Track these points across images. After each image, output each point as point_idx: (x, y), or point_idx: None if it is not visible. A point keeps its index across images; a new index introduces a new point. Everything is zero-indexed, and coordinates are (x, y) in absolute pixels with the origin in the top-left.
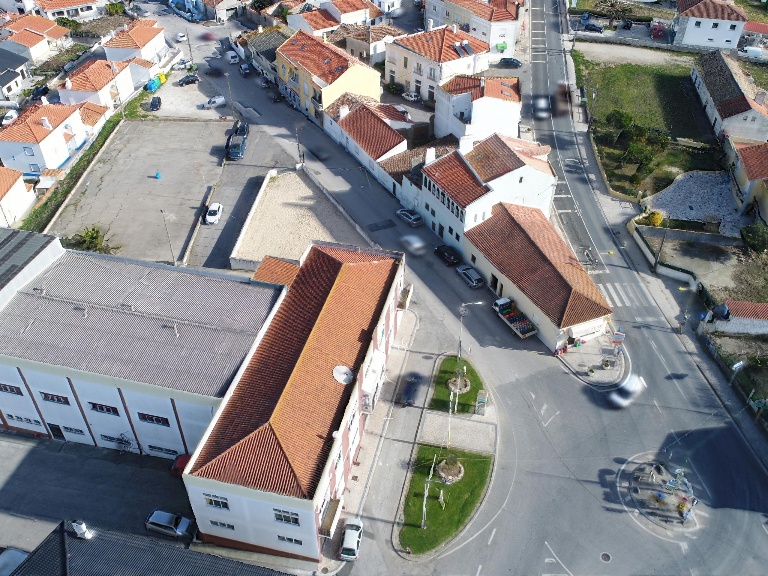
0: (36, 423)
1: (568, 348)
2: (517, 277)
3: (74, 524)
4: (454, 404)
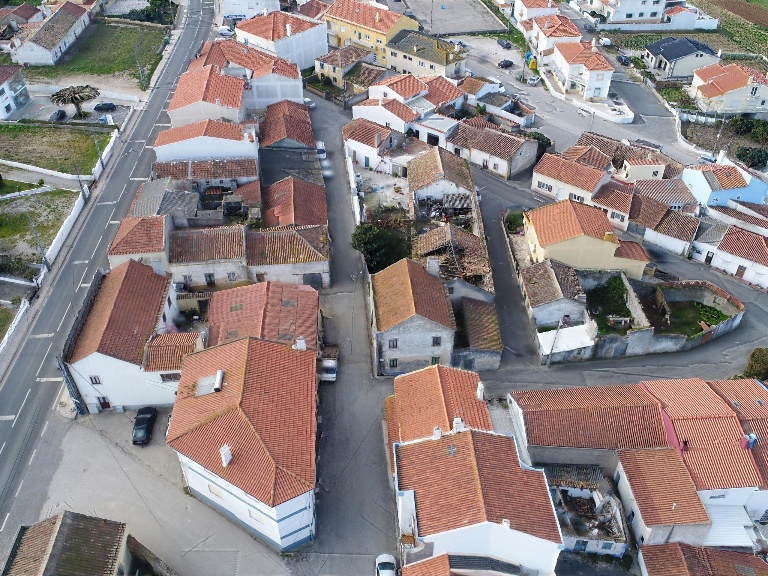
0: None
1: None
2: None
3: None
4: None
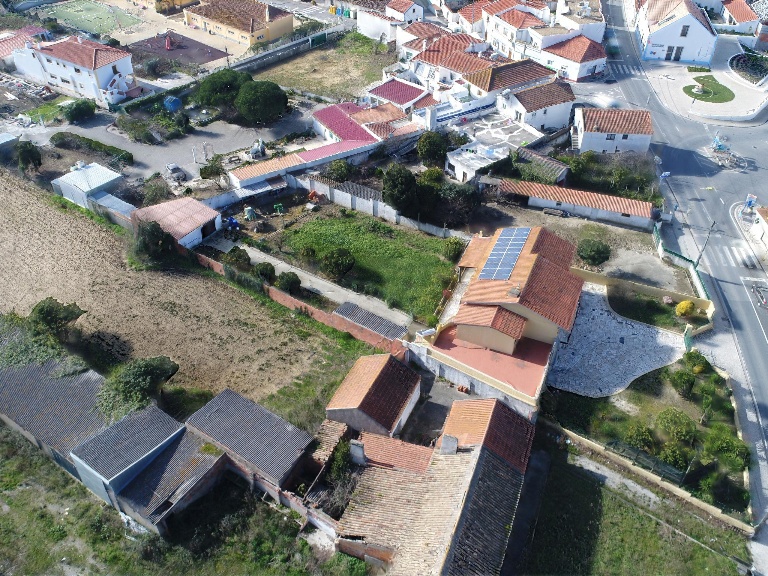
0: None
1: None
2: None
3: None
4: None
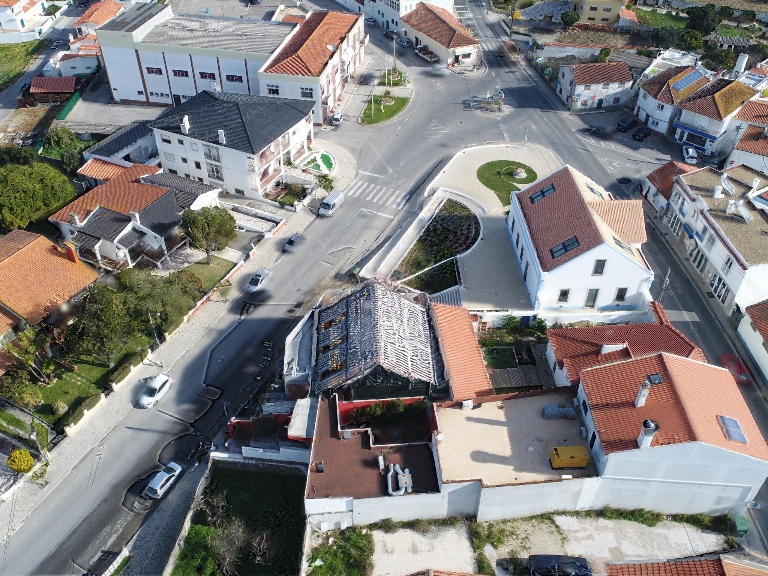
0: (166, 96)
1: (455, 65)
2: (428, 32)
3: (212, 82)
4: None
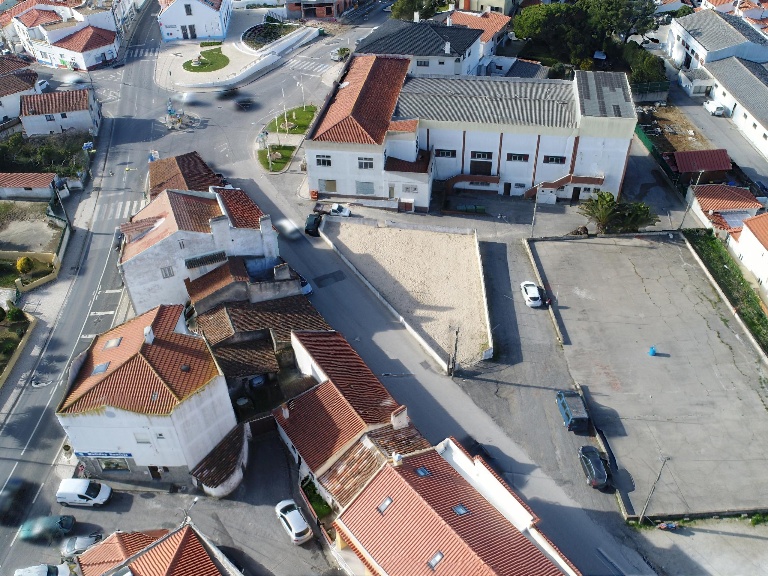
0: None
1: None
2: None
3: None
4: (280, 148)
